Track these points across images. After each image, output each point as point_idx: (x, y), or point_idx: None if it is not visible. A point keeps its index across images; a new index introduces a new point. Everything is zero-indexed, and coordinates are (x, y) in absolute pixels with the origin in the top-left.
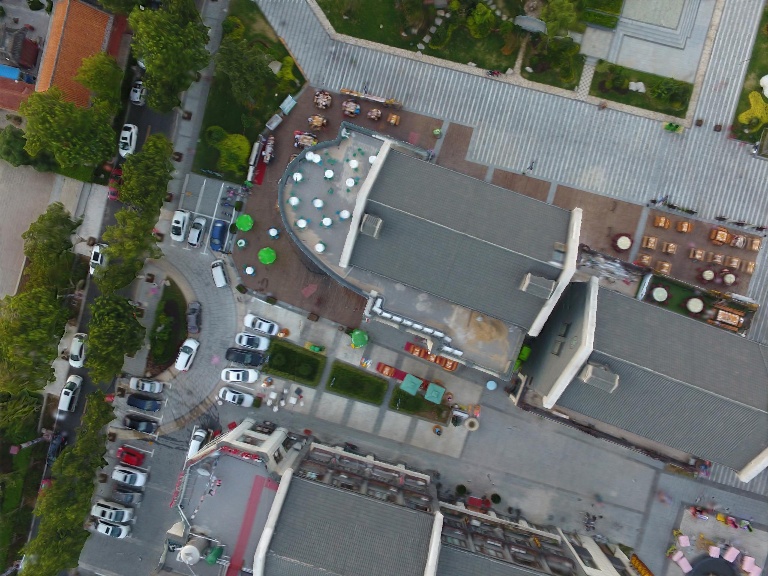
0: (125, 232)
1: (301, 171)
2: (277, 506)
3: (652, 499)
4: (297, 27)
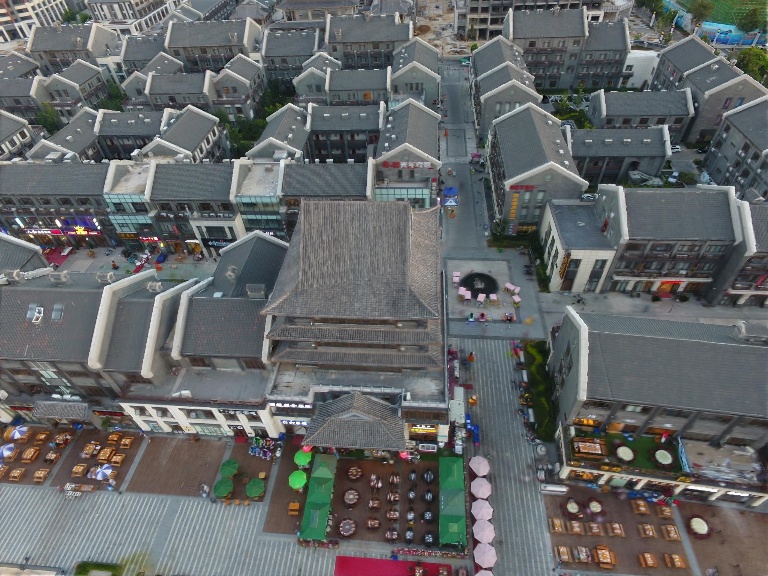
0: None
1: None
2: None
3: (542, 321)
4: None
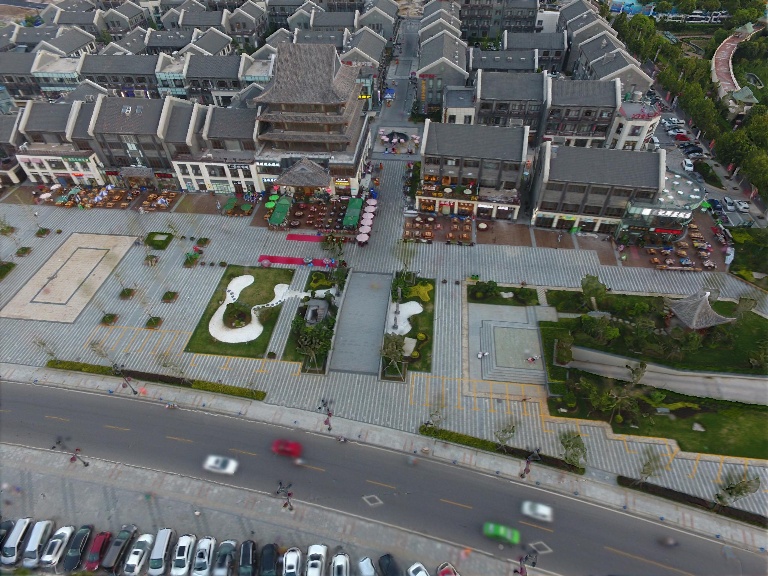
0: (765, 160)
1: (696, 193)
2: (619, 93)
3: None
4: (764, 302)
